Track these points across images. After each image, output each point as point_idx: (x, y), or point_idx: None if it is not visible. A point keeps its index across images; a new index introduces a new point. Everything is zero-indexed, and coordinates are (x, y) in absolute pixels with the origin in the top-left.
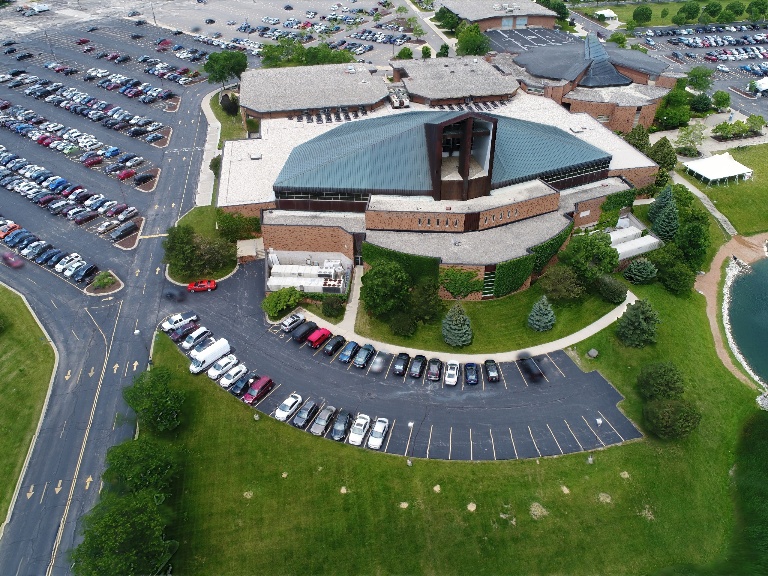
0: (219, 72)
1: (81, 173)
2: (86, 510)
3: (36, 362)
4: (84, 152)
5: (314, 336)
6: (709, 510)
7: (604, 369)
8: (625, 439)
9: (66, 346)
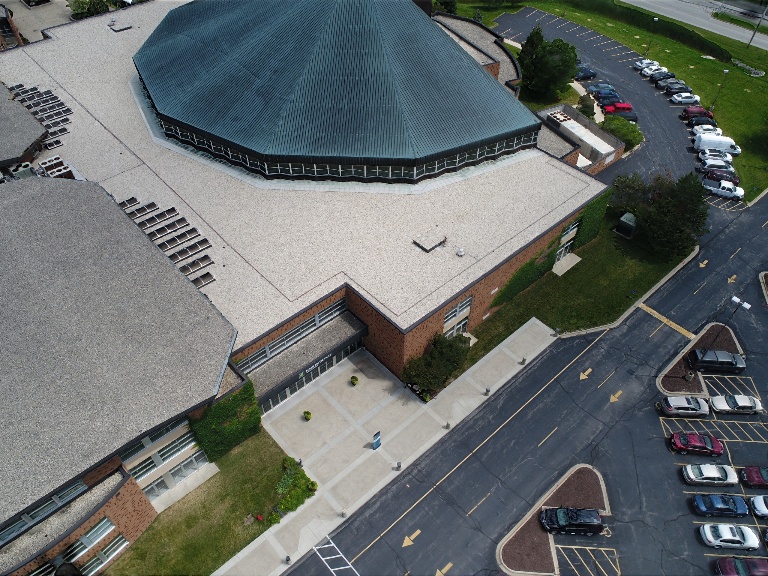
0: None
1: None
2: None
3: None
4: None
5: (626, 105)
6: (538, 3)
7: (488, 19)
8: (536, 9)
9: None
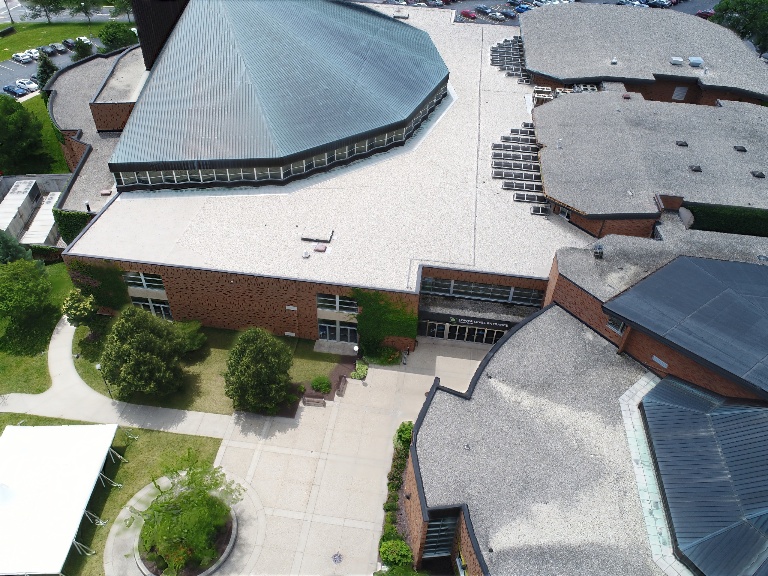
0: (716, 14)
1: (483, 3)
2: (104, 17)
3: None
4: (531, 3)
5: None
6: None
7: None
8: None
9: None
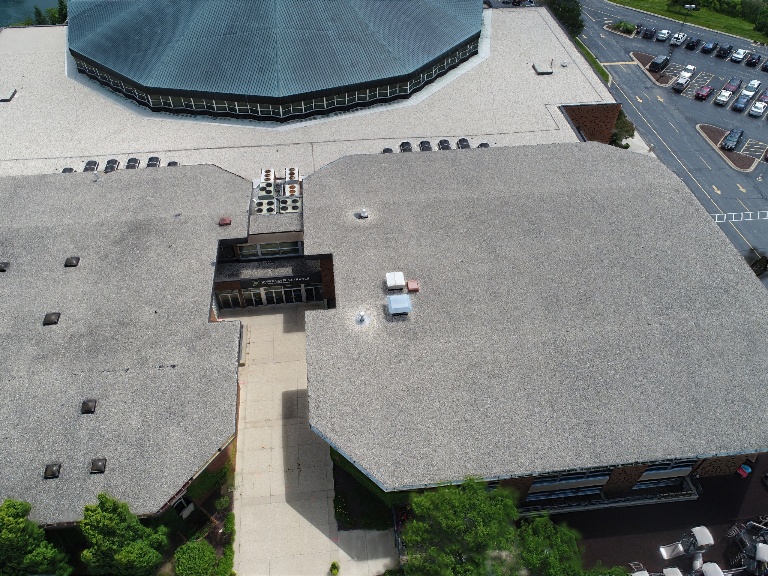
0: None
1: None
2: None
3: (619, 0)
4: None
5: None
6: None
7: None
8: None
9: (608, 5)
